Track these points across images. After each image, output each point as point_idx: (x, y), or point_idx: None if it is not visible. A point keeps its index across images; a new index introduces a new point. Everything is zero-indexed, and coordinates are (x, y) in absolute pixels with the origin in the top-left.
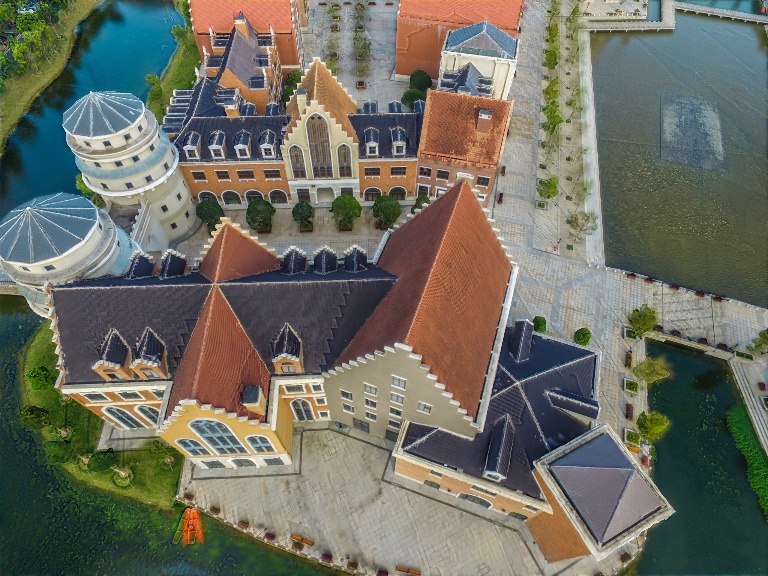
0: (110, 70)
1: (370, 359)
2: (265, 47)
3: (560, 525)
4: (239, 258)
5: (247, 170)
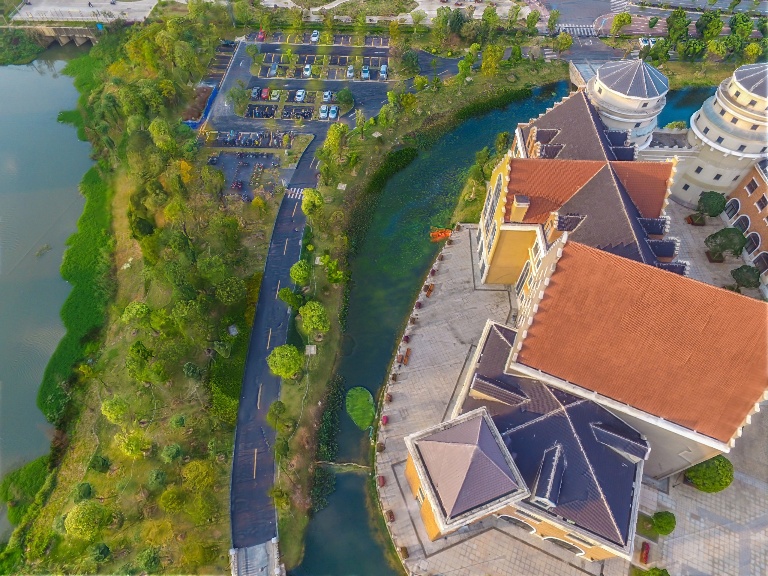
0: None
1: None
2: None
3: None
4: (642, 180)
5: None
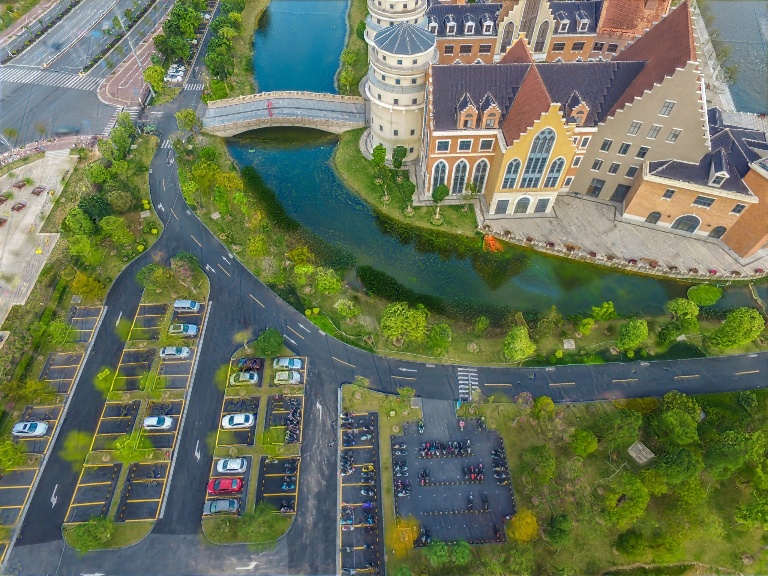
0: (306, 1)
1: (657, 86)
2: None
3: (765, 206)
4: None
5: (468, 45)
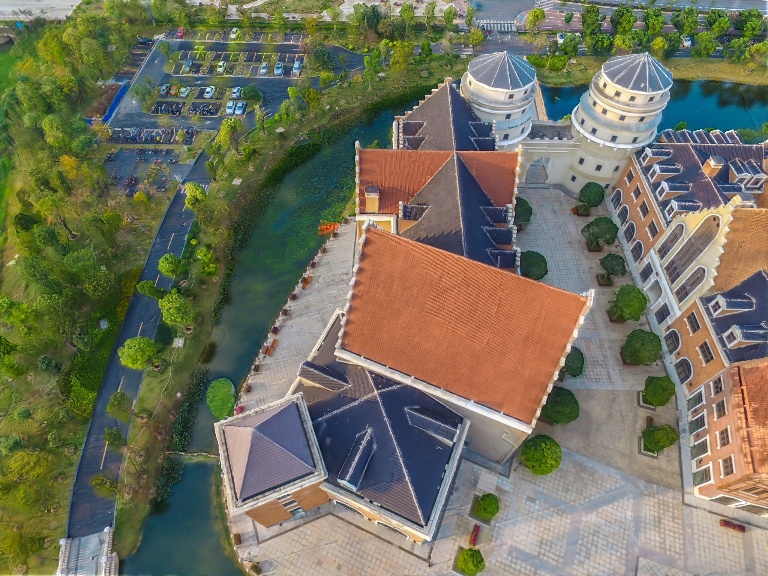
0: None
1: None
2: None
3: None
4: (490, 170)
5: (648, 206)
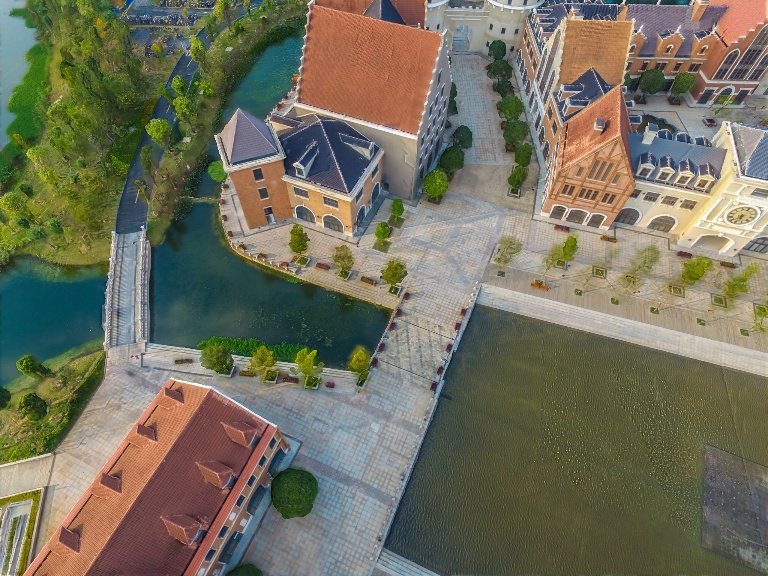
0: None
1: None
2: (696, 37)
3: None
4: (407, 3)
5: None
